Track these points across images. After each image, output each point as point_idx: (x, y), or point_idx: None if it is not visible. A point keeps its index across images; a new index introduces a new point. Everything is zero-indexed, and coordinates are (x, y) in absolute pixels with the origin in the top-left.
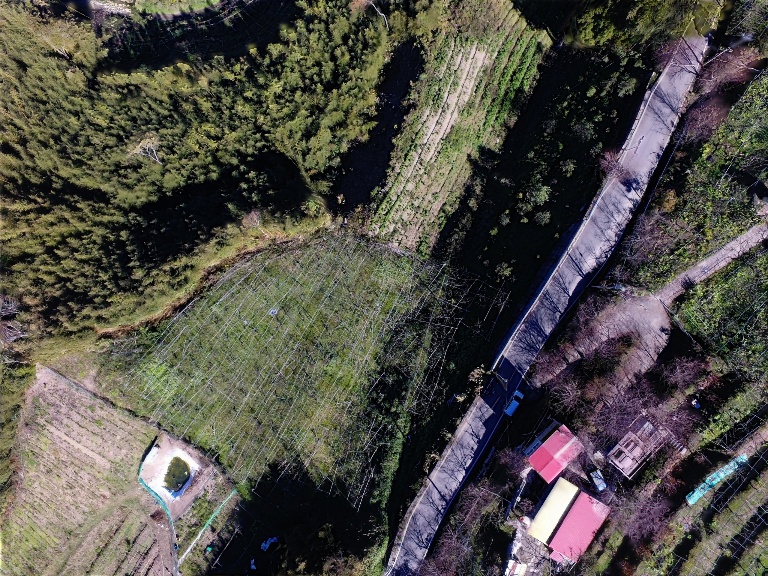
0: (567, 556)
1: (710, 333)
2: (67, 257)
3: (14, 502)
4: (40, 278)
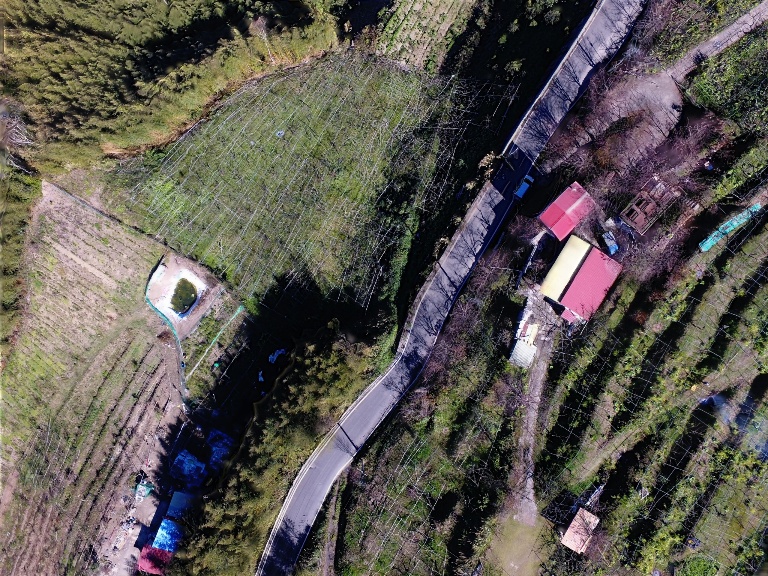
0: (579, 313)
1: (722, 103)
2: (72, 79)
3: (20, 330)
4: (46, 98)
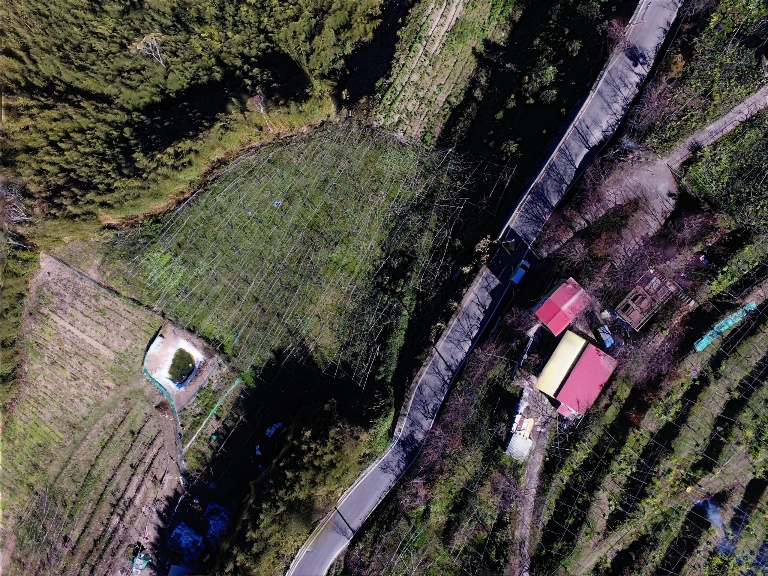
0: (574, 409)
1: (718, 194)
2: (71, 149)
3: (18, 398)
4: (44, 169)
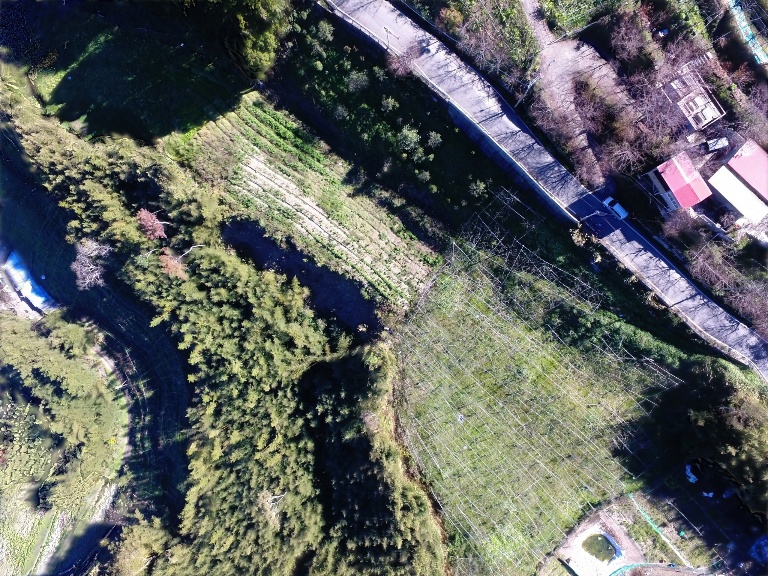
0: None
1: (594, 4)
2: None
3: None
4: None
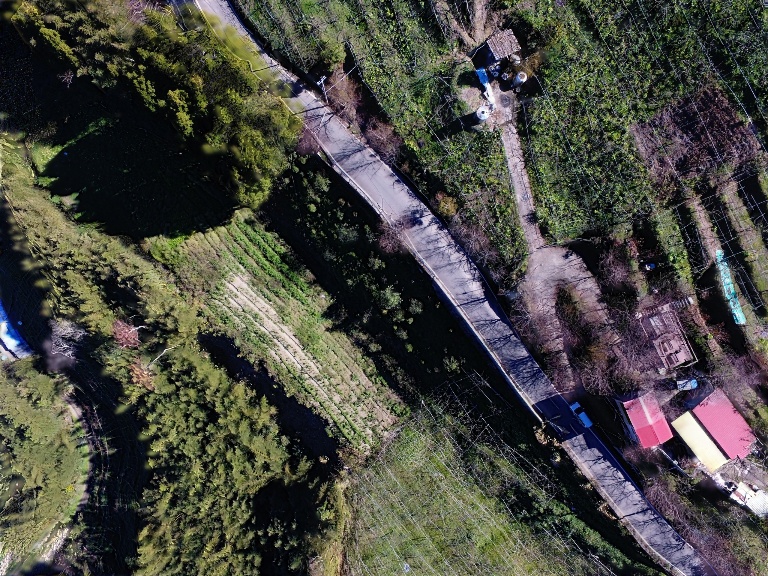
0: (747, 445)
1: None
2: None
3: None
4: None
